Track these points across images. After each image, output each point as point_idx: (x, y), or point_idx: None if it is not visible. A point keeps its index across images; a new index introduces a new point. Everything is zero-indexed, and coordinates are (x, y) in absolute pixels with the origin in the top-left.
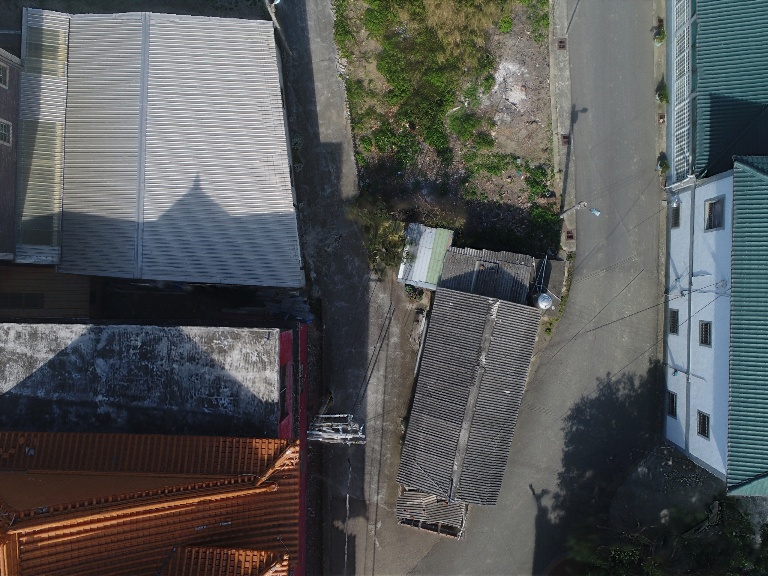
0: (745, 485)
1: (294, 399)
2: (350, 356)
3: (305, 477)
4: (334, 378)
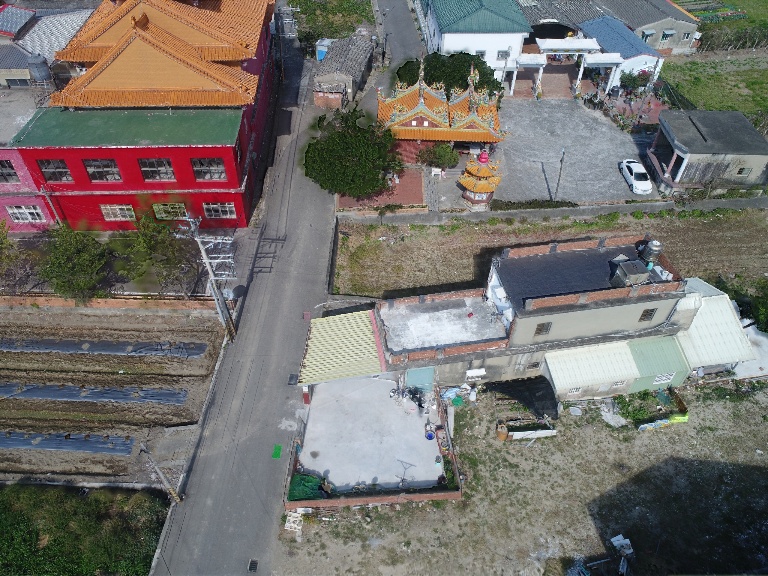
0: (445, 28)
1: (269, 50)
2: (294, 74)
3: (268, 103)
4: (286, 78)
